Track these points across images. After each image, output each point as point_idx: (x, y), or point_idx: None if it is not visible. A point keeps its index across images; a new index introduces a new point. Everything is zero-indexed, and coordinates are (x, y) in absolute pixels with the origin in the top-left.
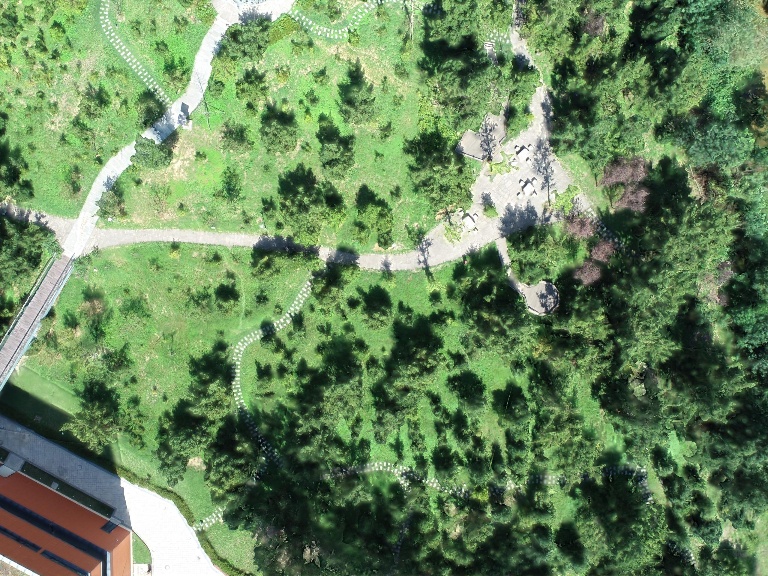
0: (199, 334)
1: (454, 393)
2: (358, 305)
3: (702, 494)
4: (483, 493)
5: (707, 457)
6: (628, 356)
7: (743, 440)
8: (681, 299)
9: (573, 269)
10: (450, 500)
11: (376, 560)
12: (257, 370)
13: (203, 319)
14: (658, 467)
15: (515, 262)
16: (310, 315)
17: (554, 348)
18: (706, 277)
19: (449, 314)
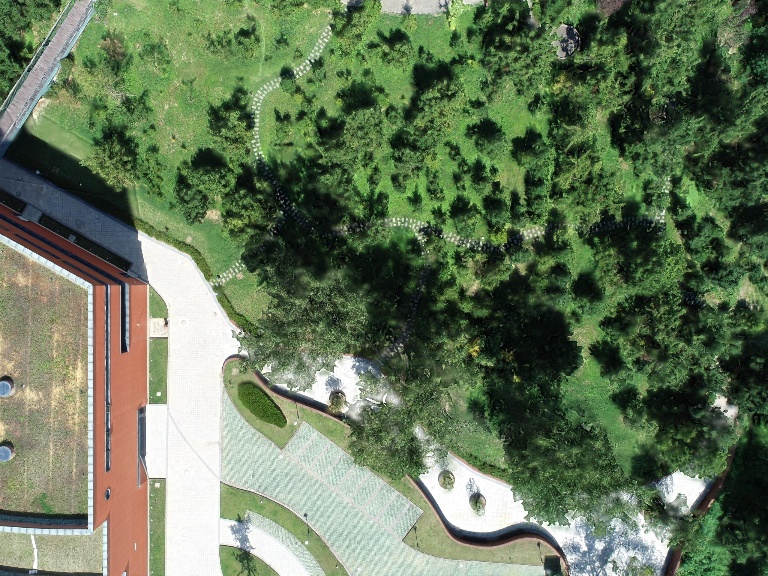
0: (219, 81)
1: (474, 136)
2: (379, 47)
3: (721, 242)
4: (502, 233)
5: (727, 190)
6: (651, 74)
7: (765, 158)
8: (705, 14)
9: (594, 14)
10: (468, 254)
11: (394, 304)
12: (276, 119)
13: (223, 56)
14: (677, 212)
15: (536, 4)
16: (330, 61)
17: (575, 82)
18: (726, 33)
19: (470, 58)
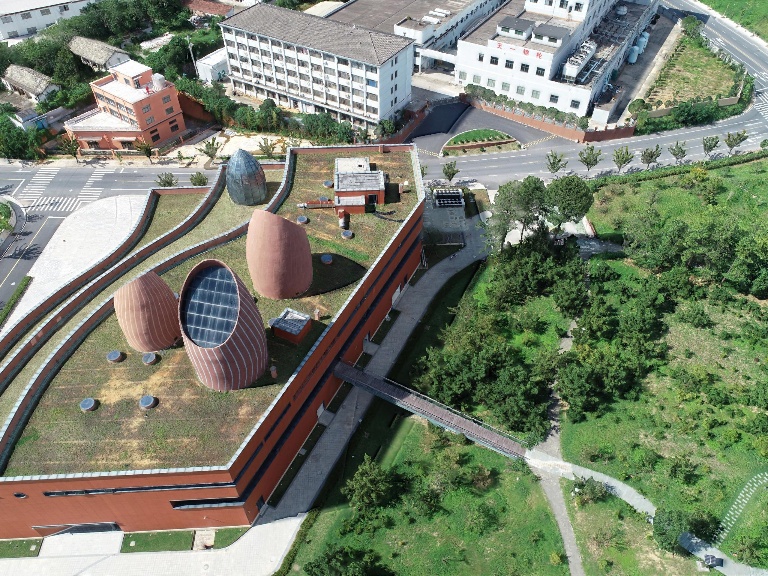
0: None
1: None
2: None
3: None
4: None
5: None
6: None
7: None
8: None
9: None
10: None
11: None
12: None
13: None
14: None
15: None
16: None
17: None
18: None
19: None
